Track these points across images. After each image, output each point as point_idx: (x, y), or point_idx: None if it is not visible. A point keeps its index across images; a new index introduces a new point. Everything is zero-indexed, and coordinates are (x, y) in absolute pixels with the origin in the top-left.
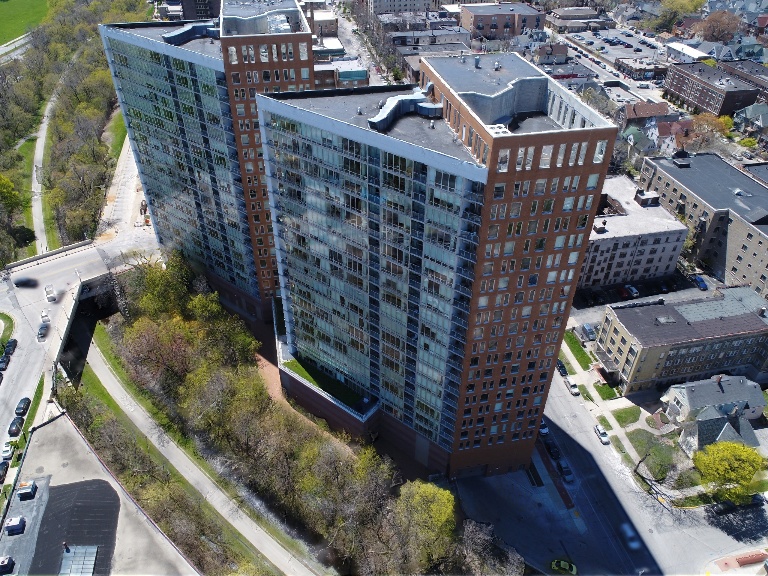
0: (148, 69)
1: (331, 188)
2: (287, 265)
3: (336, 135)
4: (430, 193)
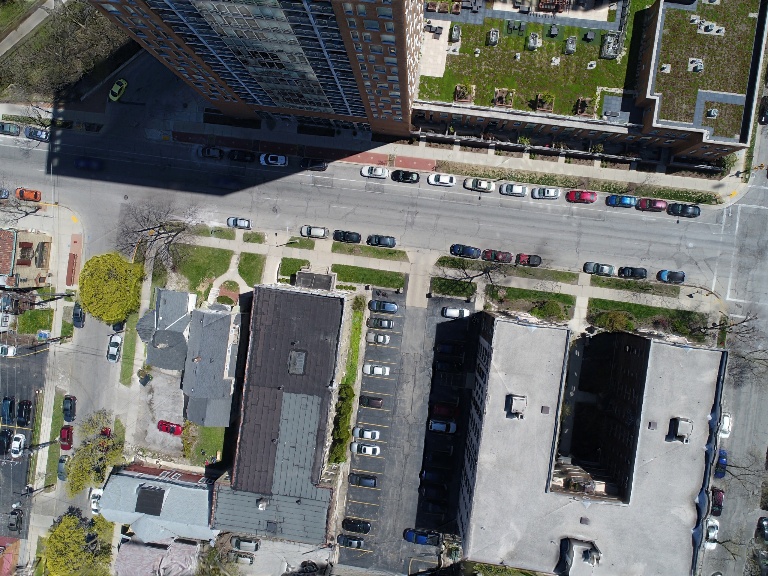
0: None
1: None
2: None
3: None
4: None
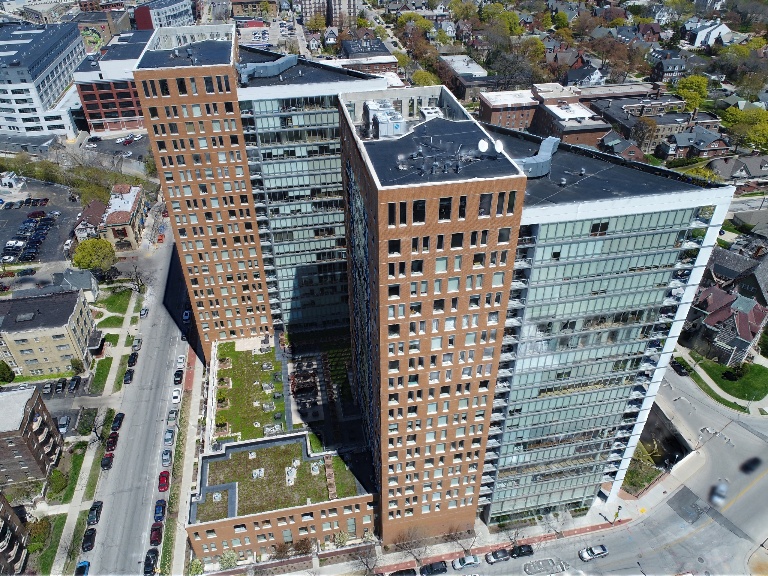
0: None
1: None
2: None
3: None
4: None
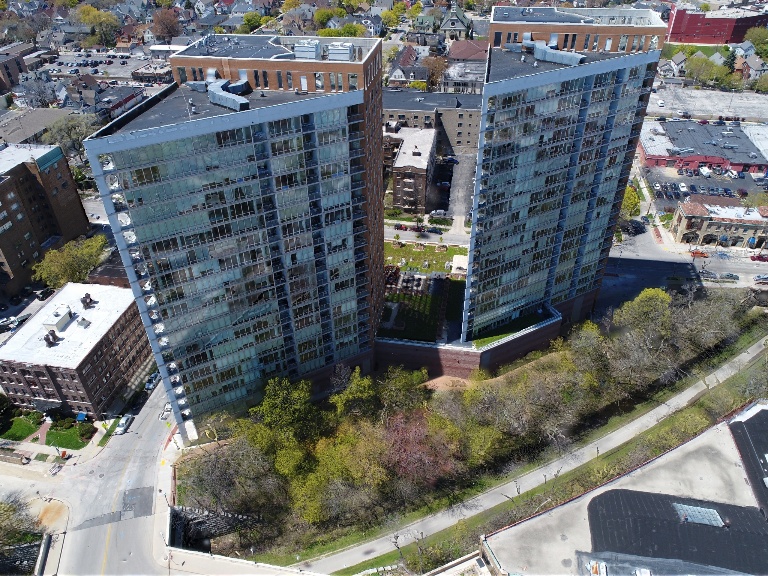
0: (211, 162)
1: (545, 134)
2: (481, 246)
3: (560, 82)
4: (623, 88)
